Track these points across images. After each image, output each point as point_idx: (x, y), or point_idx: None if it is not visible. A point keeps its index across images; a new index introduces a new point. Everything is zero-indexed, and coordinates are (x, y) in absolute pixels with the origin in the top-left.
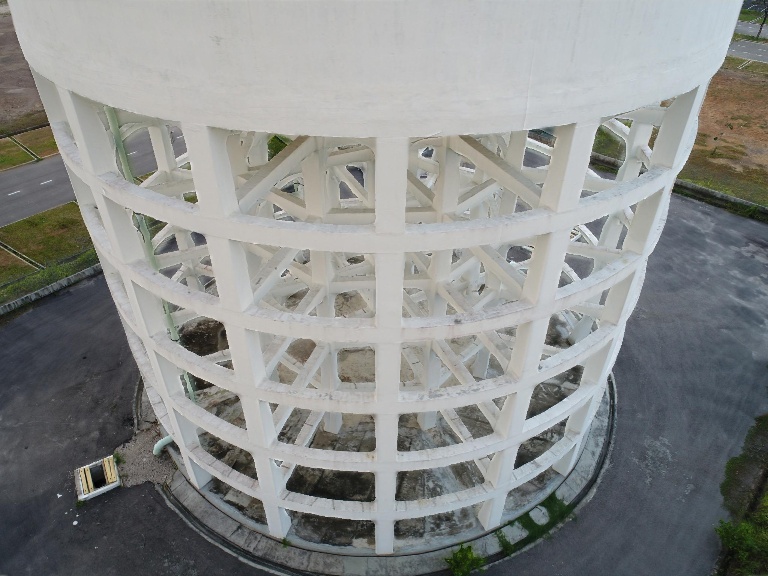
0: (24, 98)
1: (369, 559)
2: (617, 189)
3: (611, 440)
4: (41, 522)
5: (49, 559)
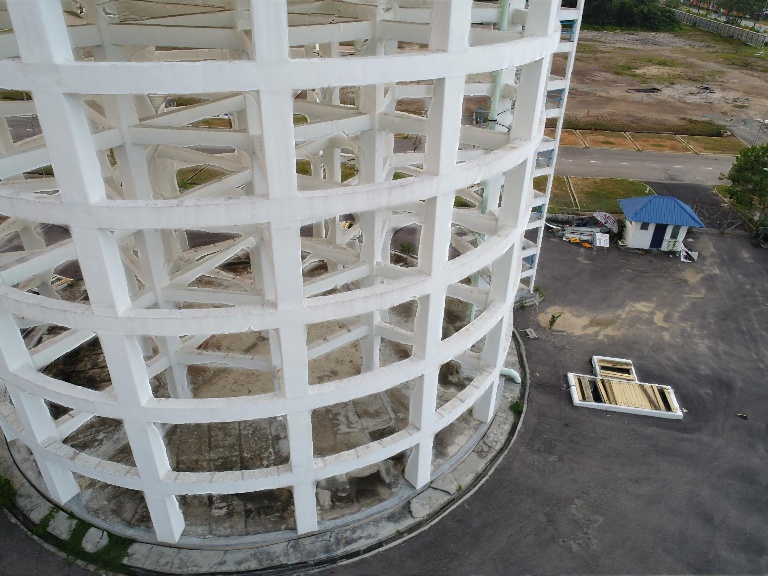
0: (416, 102)
1: (1, 433)
2: None
3: None
4: None
5: None
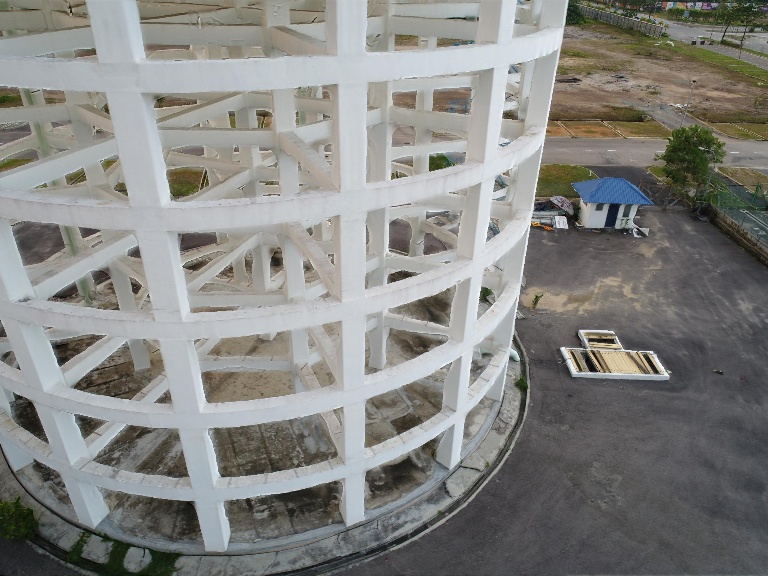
0: None
1: (4, 463)
2: None
3: (319, 574)
4: None
5: None
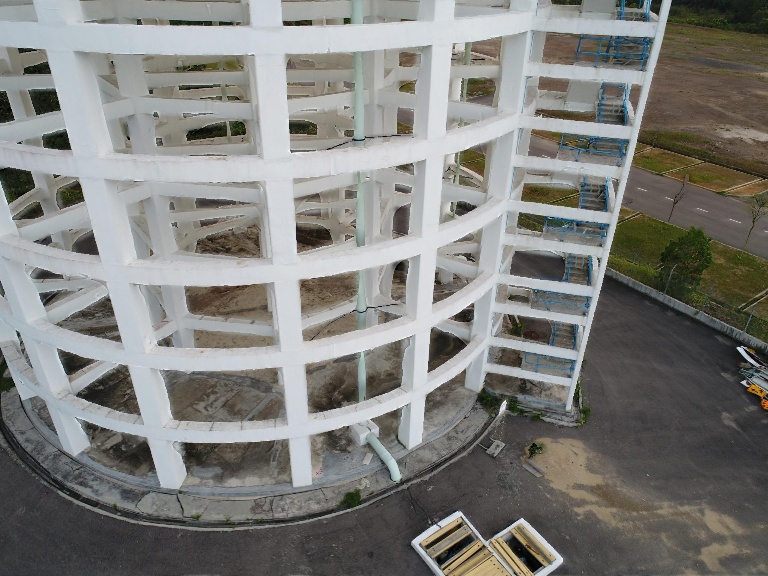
0: None
1: None
2: None
3: None
4: (217, 202)
5: None
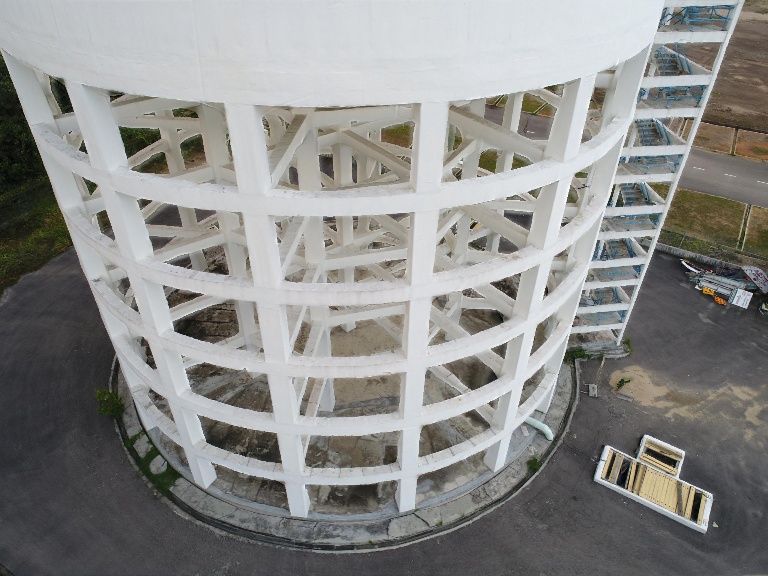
0: None
1: None
2: (58, 141)
3: None
4: None
5: (158, 238)
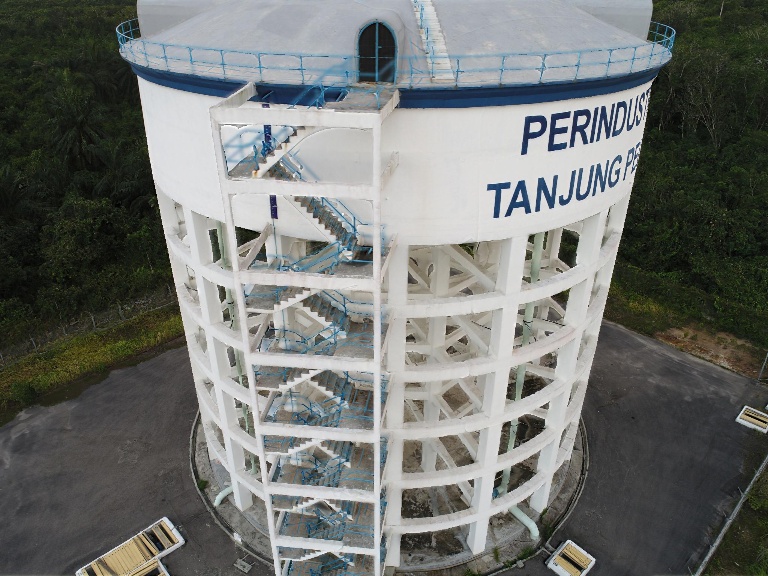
0: None
1: None
2: None
3: None
4: None
5: None
